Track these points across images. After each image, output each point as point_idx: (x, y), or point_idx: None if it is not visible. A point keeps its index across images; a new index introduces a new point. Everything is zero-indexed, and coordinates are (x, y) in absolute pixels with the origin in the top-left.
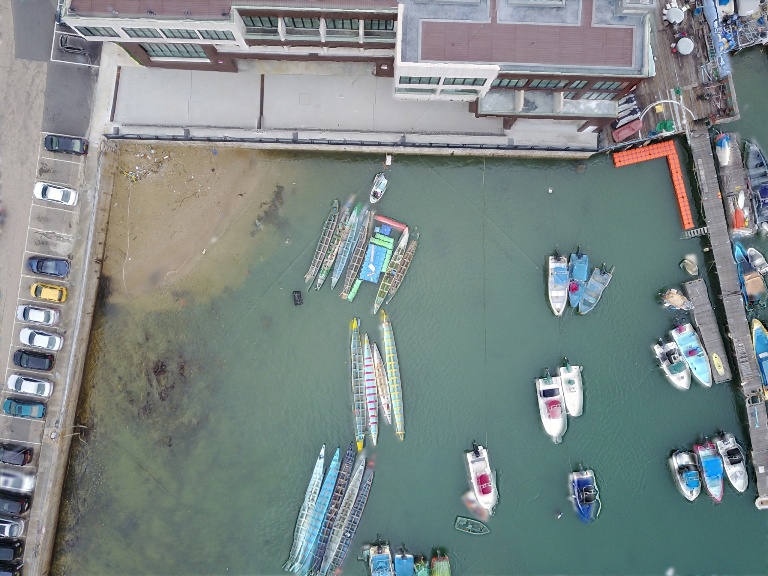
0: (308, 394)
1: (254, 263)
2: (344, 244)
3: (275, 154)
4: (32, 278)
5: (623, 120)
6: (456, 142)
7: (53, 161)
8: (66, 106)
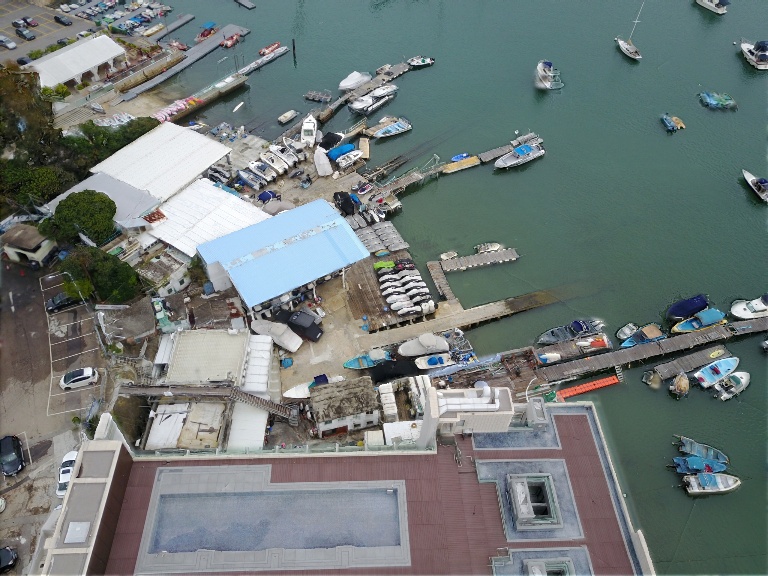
0: None
1: None
2: None
3: None
4: None
5: None
6: None
7: None
8: None
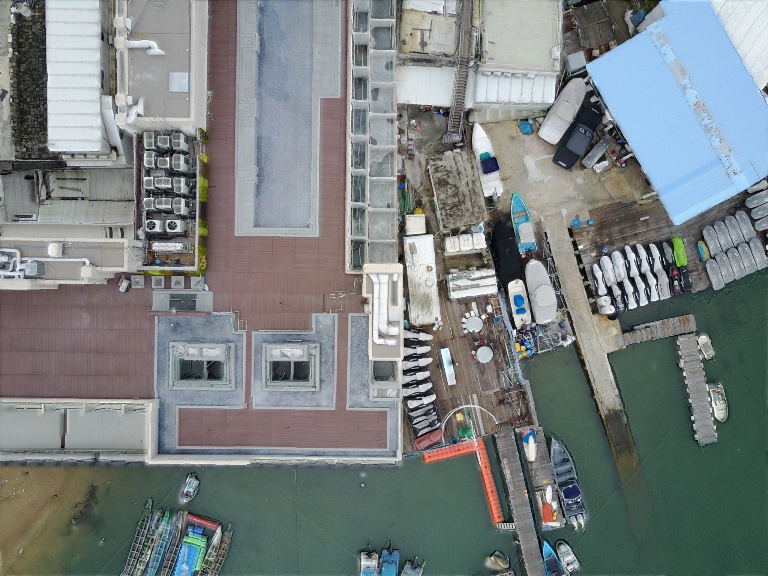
0: None
1: (71, 561)
2: (158, 543)
3: None
4: None
5: (423, 430)
6: None
7: None
8: None
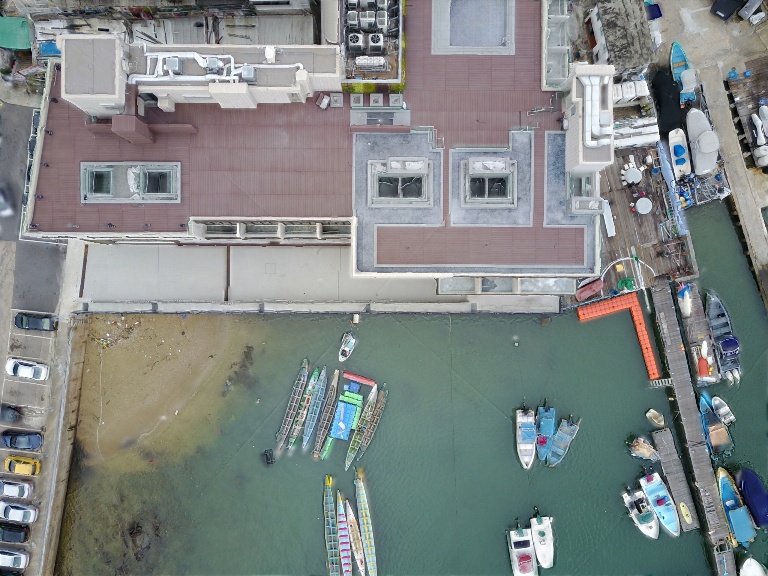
0: (282, 550)
1: (226, 422)
2: (314, 403)
3: (244, 315)
4: (6, 451)
5: (584, 281)
6: (420, 309)
7: (24, 337)
8: (35, 283)
